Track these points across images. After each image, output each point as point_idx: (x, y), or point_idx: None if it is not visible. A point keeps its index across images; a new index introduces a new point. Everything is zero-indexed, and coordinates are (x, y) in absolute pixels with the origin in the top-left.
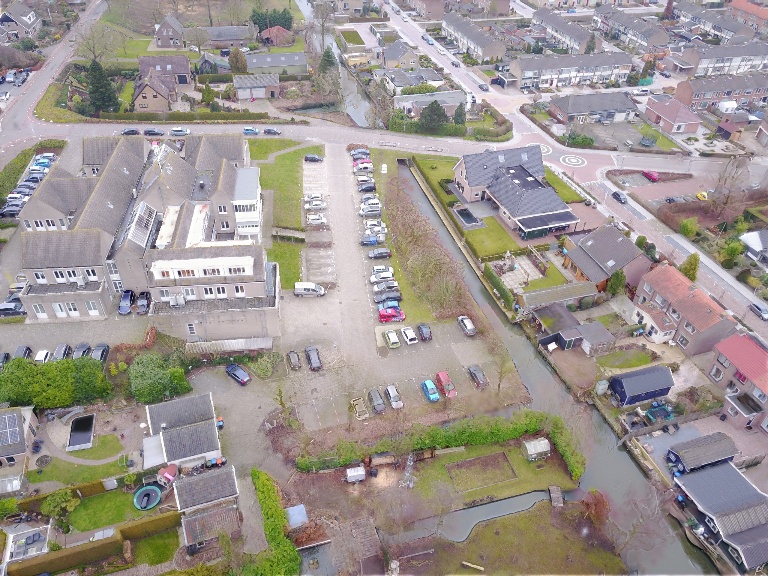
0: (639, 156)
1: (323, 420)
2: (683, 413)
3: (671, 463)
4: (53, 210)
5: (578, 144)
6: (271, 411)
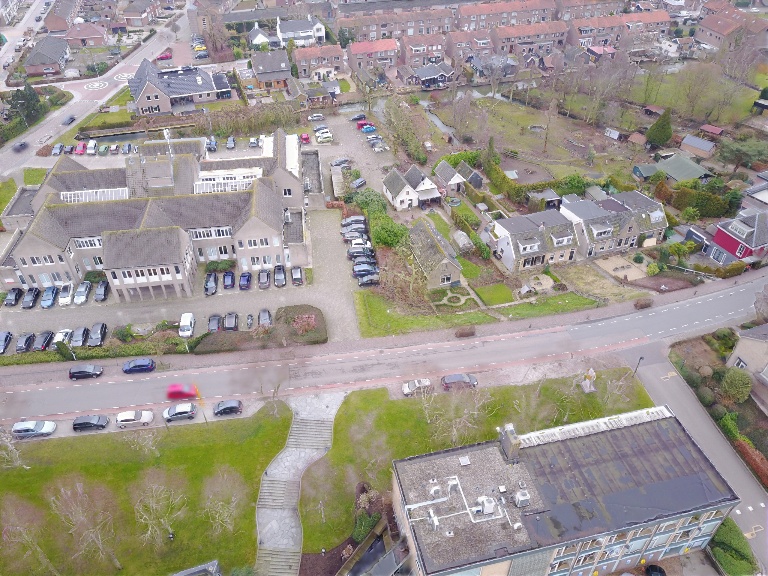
0: (131, 58)
1: (391, 159)
2: (384, 75)
3: (411, 82)
4: (185, 234)
5: (104, 70)
6: (385, 175)
